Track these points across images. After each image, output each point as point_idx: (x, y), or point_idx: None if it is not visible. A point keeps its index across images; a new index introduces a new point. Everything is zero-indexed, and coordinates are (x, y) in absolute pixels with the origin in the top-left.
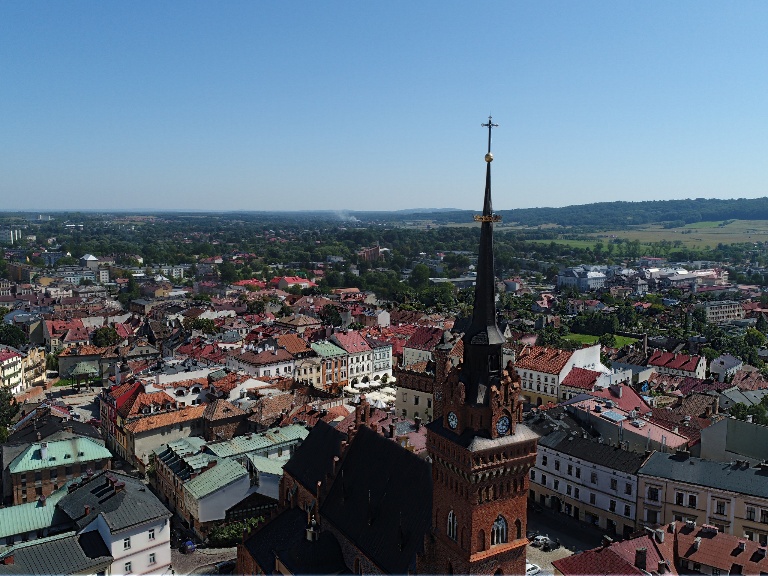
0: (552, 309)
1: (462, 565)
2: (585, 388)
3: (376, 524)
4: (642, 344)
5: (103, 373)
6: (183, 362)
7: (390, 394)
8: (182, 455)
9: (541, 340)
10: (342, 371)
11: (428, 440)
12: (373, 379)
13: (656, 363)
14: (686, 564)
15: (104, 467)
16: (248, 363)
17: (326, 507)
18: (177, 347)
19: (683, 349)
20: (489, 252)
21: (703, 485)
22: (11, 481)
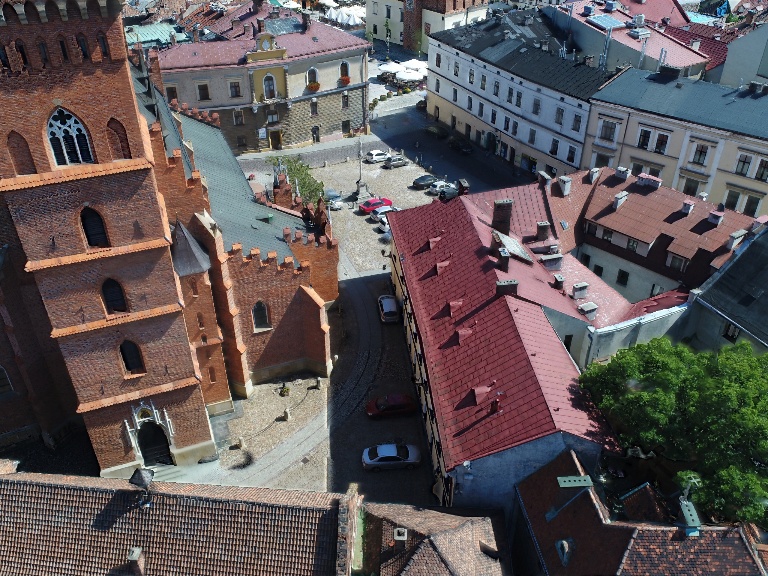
0: None
1: None
2: None
3: None
4: None
5: None
6: None
7: None
8: None
9: None
10: None
11: None
12: None
13: None
14: (594, 229)
15: None
16: None
17: None
18: None
19: None
20: None
21: (680, 118)
22: None
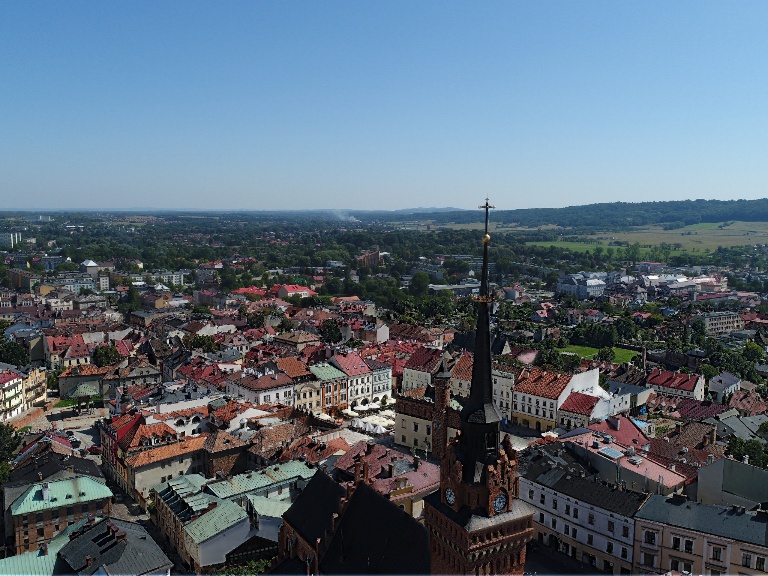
0: (551, 319)
1: None
2: (583, 414)
3: None
4: (641, 358)
5: (104, 394)
6: (183, 388)
7: (389, 417)
8: (182, 495)
9: (540, 357)
10: (342, 394)
11: (426, 512)
12: (372, 401)
13: (655, 382)
14: None
15: (105, 506)
16: (248, 388)
17: (325, 564)
18: (177, 367)
19: (682, 364)
20: (486, 331)
21: (699, 531)
22: (13, 522)
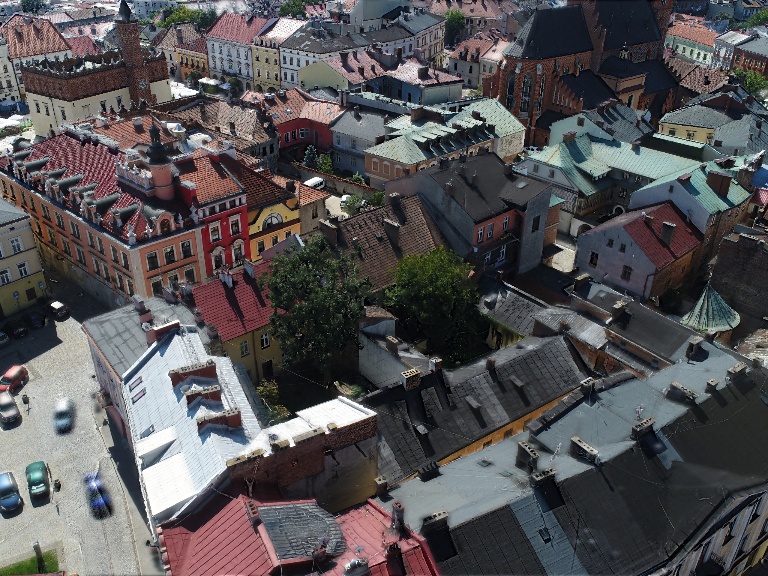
0: None
1: None
2: None
3: None
4: None
5: None
6: None
7: None
8: None
9: None
10: None
11: None
12: None
13: None
14: None
15: None
16: None
17: None
18: None
19: None
20: None
21: None
22: None
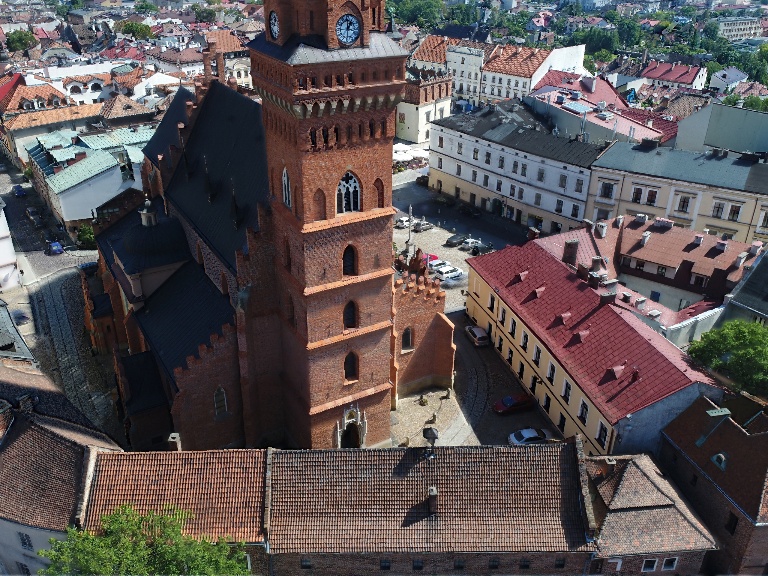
0: None
1: (296, 239)
2: None
3: (216, 201)
4: None
5: None
6: (89, 59)
7: None
8: (49, 148)
9: None
10: None
11: (252, 67)
12: None
13: (650, 75)
14: (628, 262)
15: None
16: (168, 61)
17: (172, 187)
18: (101, 52)
19: None
20: None
21: (667, 177)
22: None
